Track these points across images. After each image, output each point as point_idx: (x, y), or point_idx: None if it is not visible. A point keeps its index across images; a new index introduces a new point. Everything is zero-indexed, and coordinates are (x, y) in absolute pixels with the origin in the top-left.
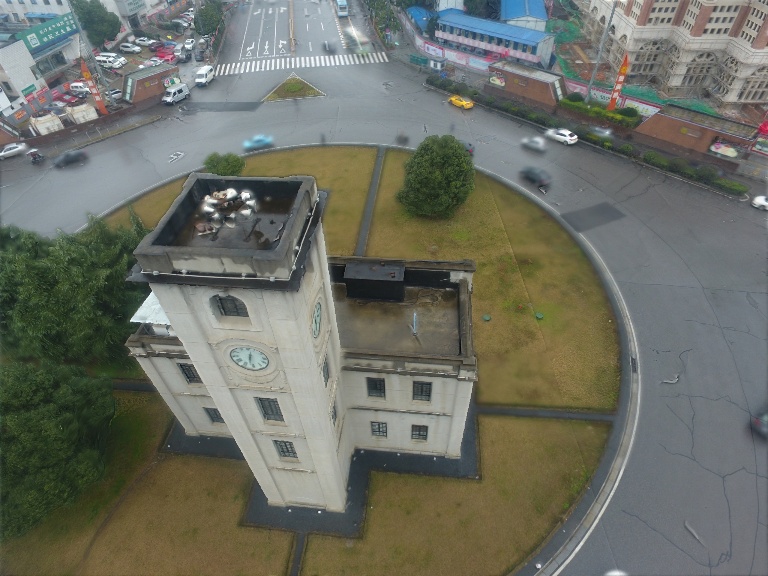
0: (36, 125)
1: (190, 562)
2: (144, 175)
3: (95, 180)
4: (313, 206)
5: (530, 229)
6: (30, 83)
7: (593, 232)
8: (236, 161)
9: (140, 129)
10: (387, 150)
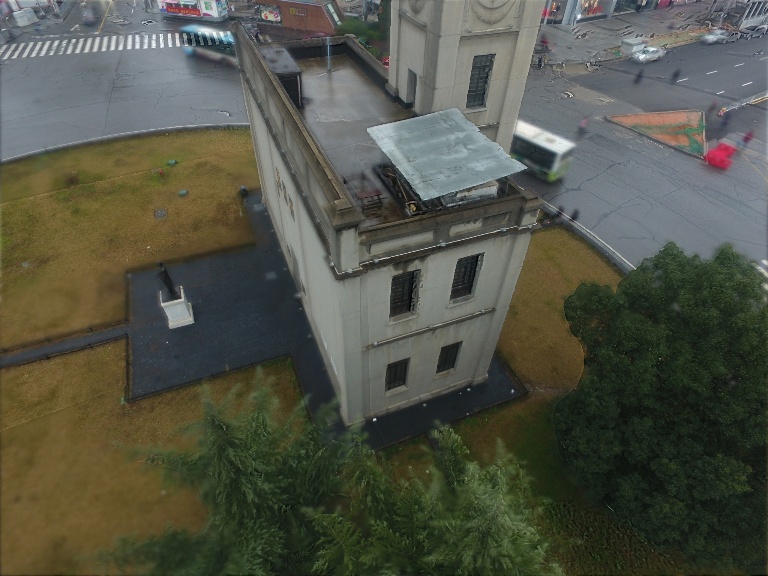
0: None
1: (567, 292)
2: None
3: None
4: None
5: None
6: None
7: (1, 153)
8: None
9: None
10: None
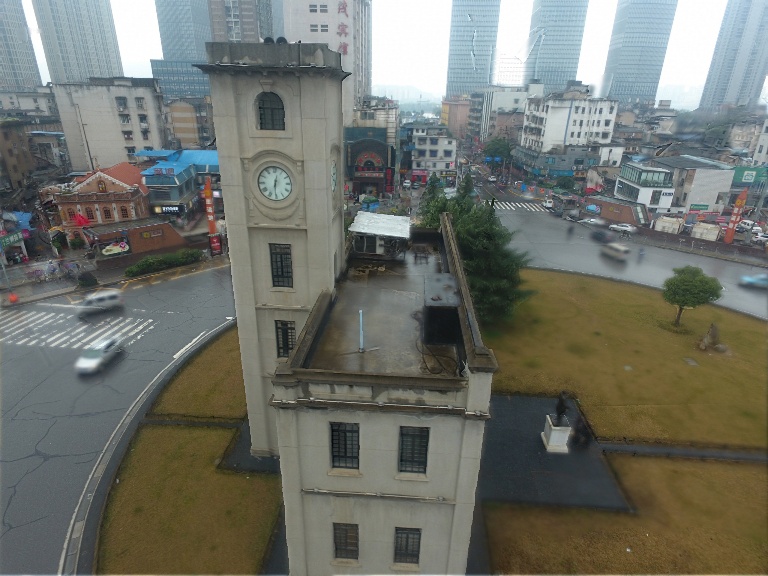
0: (657, 220)
1: None
2: (660, 278)
3: (626, 261)
4: (303, 65)
5: None
6: (706, 203)
7: None
8: (702, 282)
9: (734, 263)
10: None
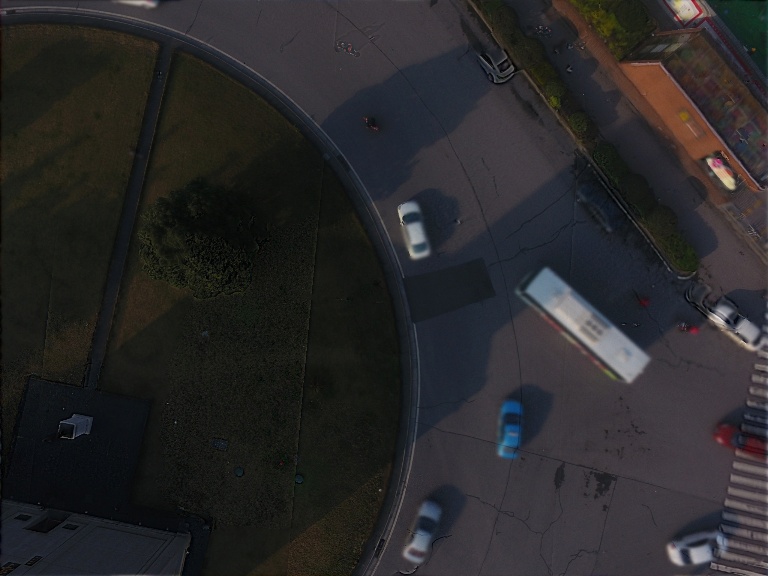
0: None
1: None
2: None
3: None
4: None
5: (346, 313)
6: None
7: (434, 323)
8: None
9: None
10: (175, 55)
